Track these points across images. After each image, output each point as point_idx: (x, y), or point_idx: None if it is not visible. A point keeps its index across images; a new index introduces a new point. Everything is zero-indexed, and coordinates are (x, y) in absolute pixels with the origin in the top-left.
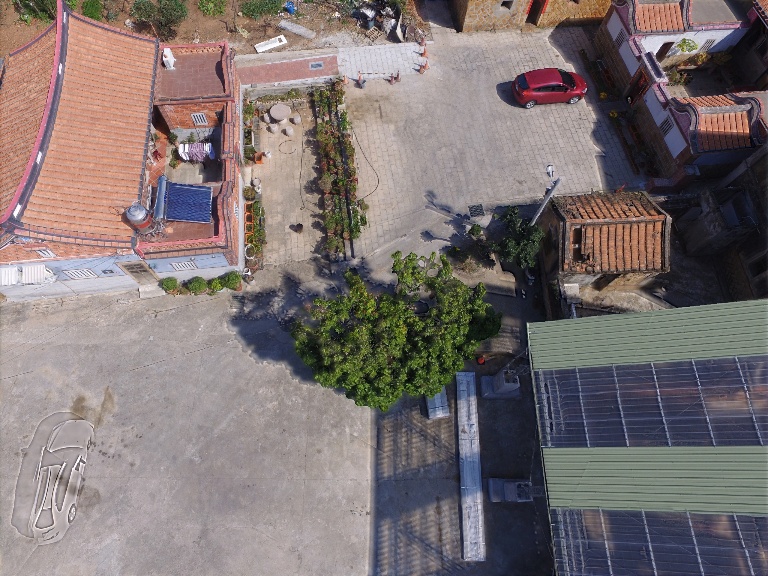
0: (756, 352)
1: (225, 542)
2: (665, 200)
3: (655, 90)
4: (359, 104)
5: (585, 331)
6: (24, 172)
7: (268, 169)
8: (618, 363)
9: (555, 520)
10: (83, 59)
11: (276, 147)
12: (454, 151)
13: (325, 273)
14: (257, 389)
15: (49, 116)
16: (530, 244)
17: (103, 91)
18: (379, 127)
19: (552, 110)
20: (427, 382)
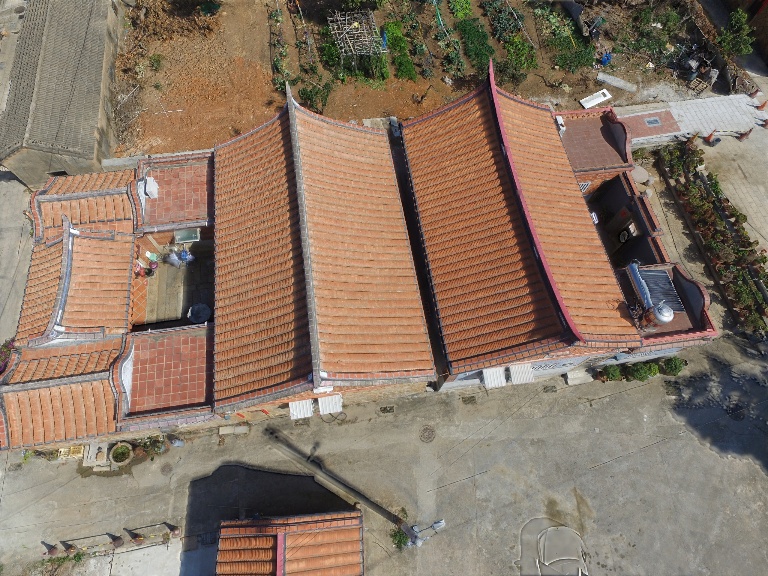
0: None
1: None
2: None
3: None
4: (717, 164)
5: None
6: None
7: None
8: None
9: None
10: (512, 135)
11: None
12: None
13: (753, 354)
14: (734, 488)
15: None
16: None
17: (539, 169)
18: (748, 189)
19: None
20: None
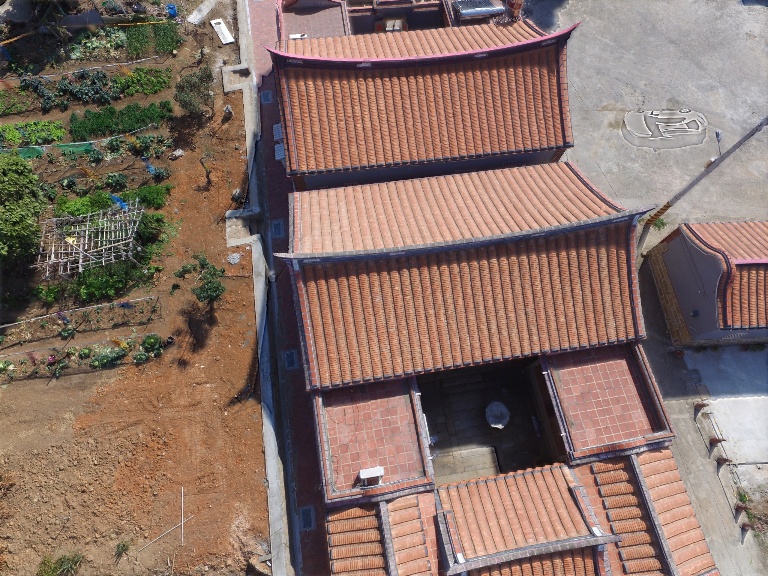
0: None
1: (675, 32)
2: None
3: None
4: None
5: None
6: (503, 50)
7: None
8: None
9: None
10: None
11: None
12: None
13: None
14: None
15: None
16: None
17: None
18: None
19: None
20: None
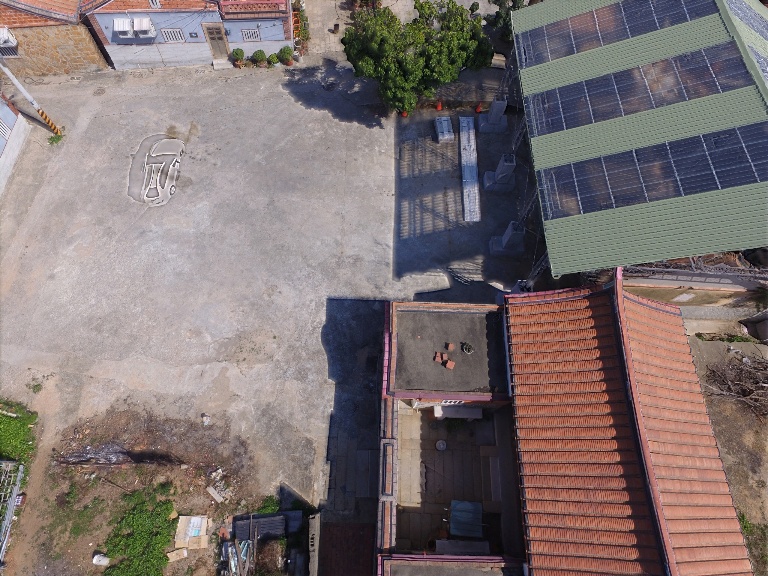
0: None
1: (287, 208)
2: None
3: None
4: None
5: (550, 6)
6: None
7: None
8: (572, 15)
9: (527, 102)
10: None
11: None
12: None
13: None
14: (307, 124)
15: None
16: None
17: None
18: None
19: None
20: (440, 66)
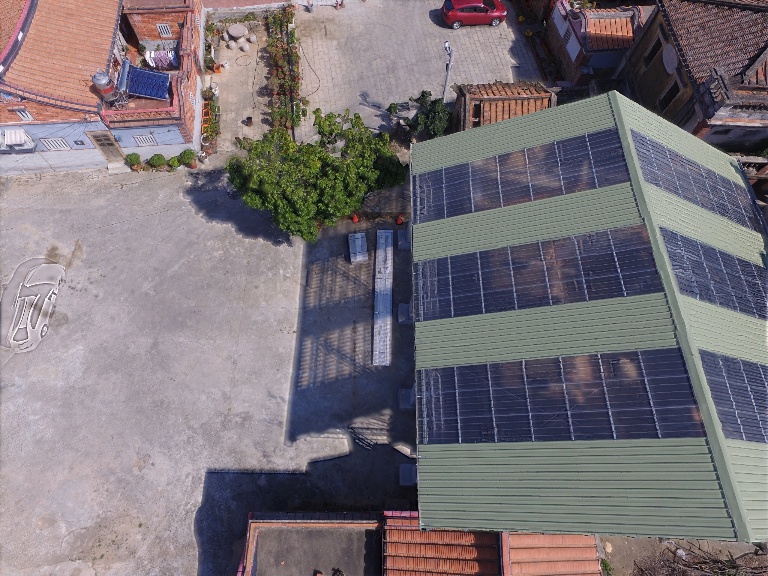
0: (569, 136)
1: (173, 351)
2: (559, 90)
3: (559, 6)
4: (307, 25)
5: (452, 142)
6: (7, 44)
7: (225, 77)
8: (473, 160)
9: (416, 270)
10: None
11: (233, 60)
12: (388, 61)
13: None
14: (206, 242)
15: (30, 6)
16: (437, 117)
17: None
18: (323, 42)
19: (476, 31)
20: (335, 201)
